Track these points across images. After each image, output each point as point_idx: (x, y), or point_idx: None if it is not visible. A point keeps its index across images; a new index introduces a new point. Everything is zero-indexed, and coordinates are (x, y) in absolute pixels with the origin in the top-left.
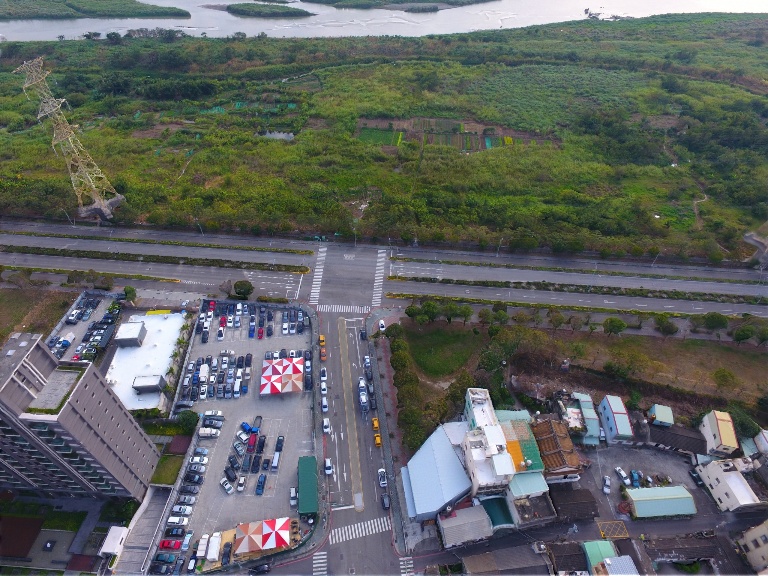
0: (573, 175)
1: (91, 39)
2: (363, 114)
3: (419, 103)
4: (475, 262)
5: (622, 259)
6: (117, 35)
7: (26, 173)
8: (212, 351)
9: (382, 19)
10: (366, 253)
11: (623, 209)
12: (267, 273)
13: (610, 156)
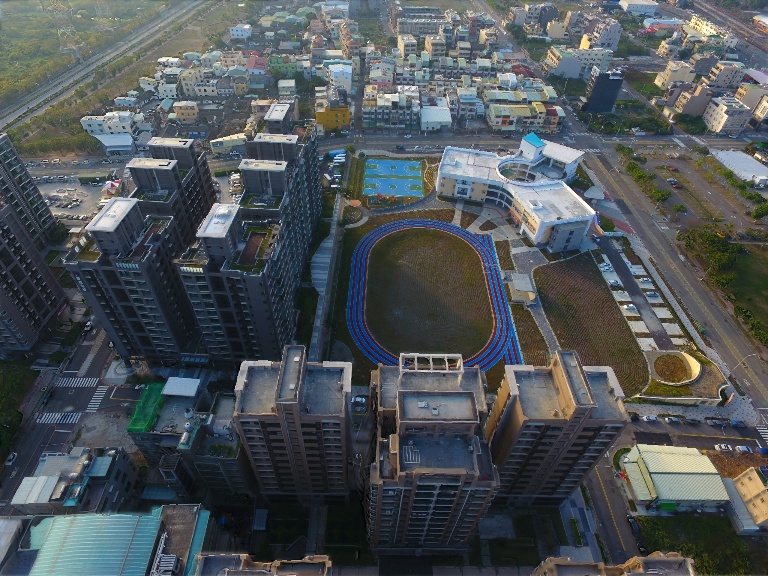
0: None
1: None
2: None
3: None
4: None
5: (37, 88)
6: None
7: None
8: None
9: None
10: None
11: None
12: None
13: None
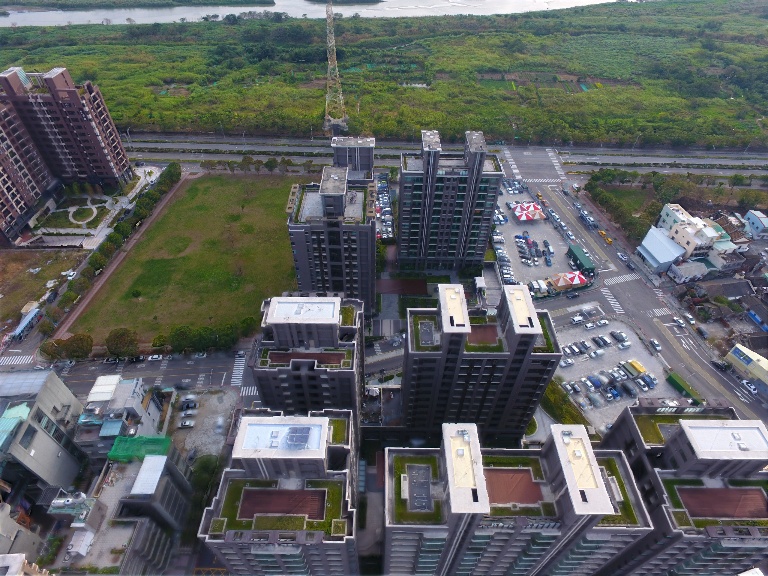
0: (661, 105)
1: (210, 21)
2: (476, 70)
3: (517, 61)
4: (619, 154)
5: (722, 150)
6: (235, 16)
7: (237, 112)
8: None
9: (444, 4)
10: (538, 151)
11: (707, 124)
12: None
13: (683, 93)
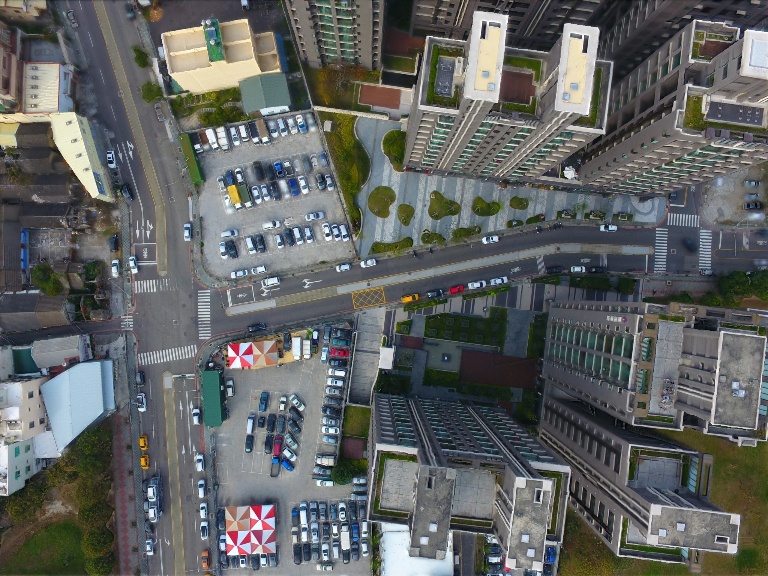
0: None
1: None
2: None
3: None
4: None
5: None
6: None
7: None
8: (346, 571)
9: None
10: None
11: None
12: None
13: None
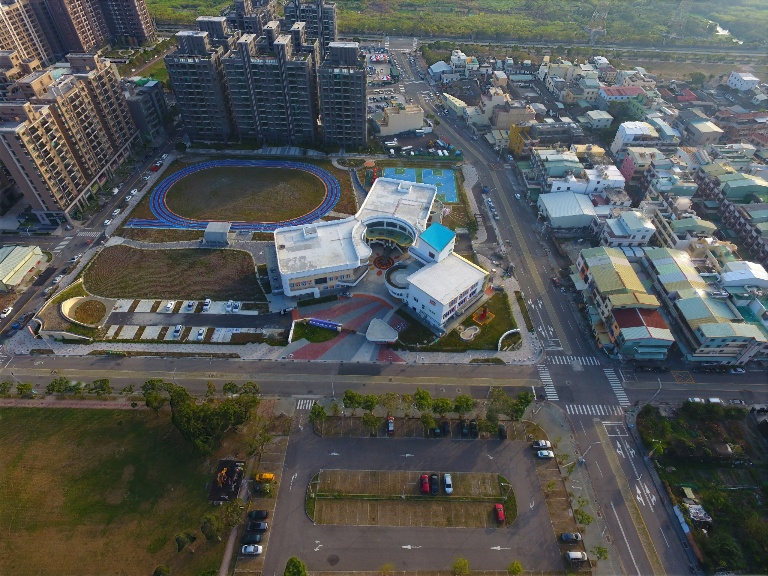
0: (514, 23)
1: None
2: (399, 4)
3: (431, 0)
4: None
5: (528, 41)
6: None
7: None
8: None
9: None
10: (408, 38)
11: None
12: (364, 42)
13: (536, 18)
